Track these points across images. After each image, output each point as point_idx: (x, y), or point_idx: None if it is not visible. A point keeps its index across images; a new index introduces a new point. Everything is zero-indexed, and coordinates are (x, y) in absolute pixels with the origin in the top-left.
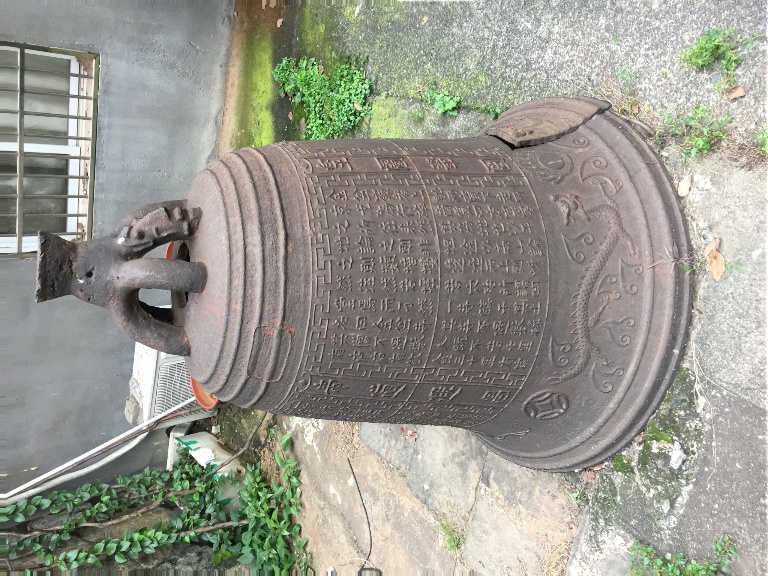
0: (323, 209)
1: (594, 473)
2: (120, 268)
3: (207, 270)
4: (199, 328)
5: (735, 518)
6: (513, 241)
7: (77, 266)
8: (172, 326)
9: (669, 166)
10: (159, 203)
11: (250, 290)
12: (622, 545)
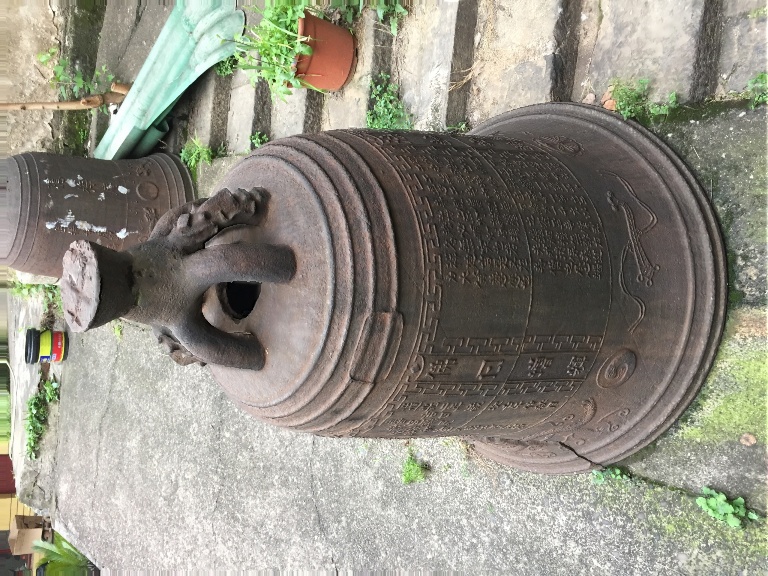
0: None
1: None
2: None
3: None
4: None
5: None
6: None
7: None
8: None
9: None
10: None
11: None
12: None
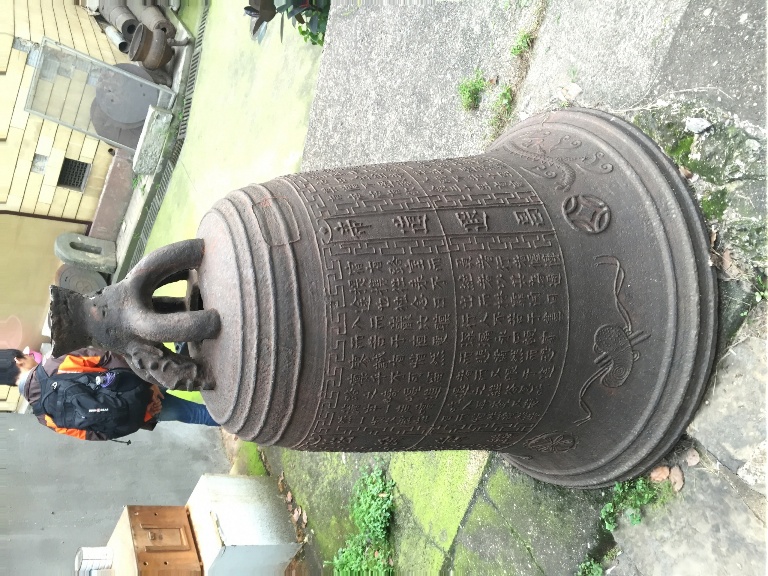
0: None
1: (724, 250)
2: None
3: None
4: (214, 277)
5: (765, 65)
6: None
7: None
8: None
9: None
10: None
11: None
12: None
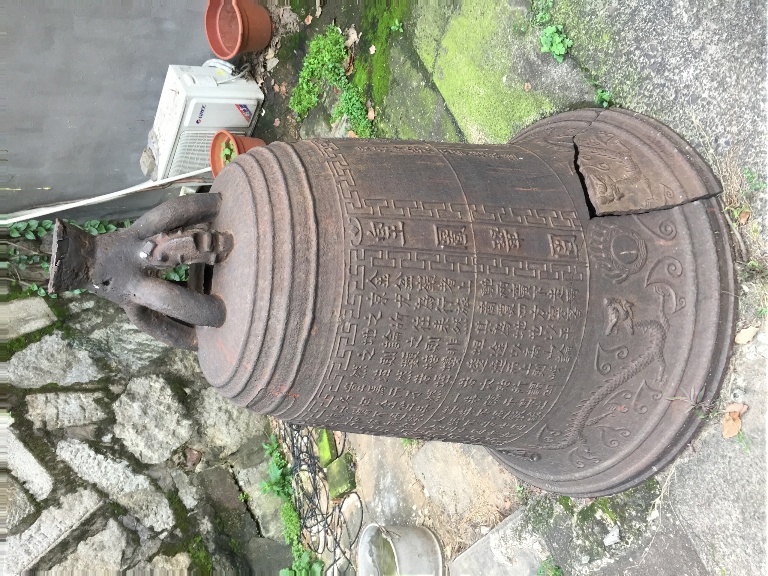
0: (359, 296)
1: None
2: (138, 287)
3: (226, 313)
4: (209, 347)
5: None
6: (545, 346)
7: (94, 273)
8: (184, 326)
9: (742, 303)
10: (191, 200)
11: (264, 358)
12: (539, 550)
